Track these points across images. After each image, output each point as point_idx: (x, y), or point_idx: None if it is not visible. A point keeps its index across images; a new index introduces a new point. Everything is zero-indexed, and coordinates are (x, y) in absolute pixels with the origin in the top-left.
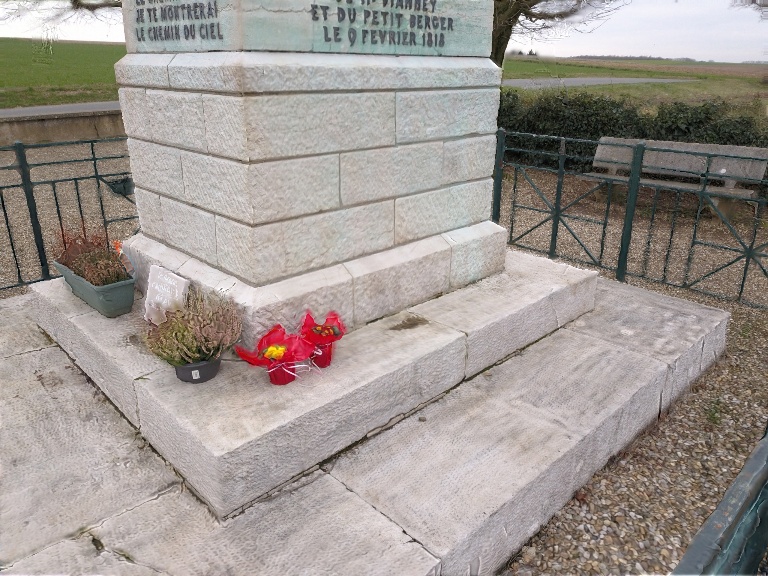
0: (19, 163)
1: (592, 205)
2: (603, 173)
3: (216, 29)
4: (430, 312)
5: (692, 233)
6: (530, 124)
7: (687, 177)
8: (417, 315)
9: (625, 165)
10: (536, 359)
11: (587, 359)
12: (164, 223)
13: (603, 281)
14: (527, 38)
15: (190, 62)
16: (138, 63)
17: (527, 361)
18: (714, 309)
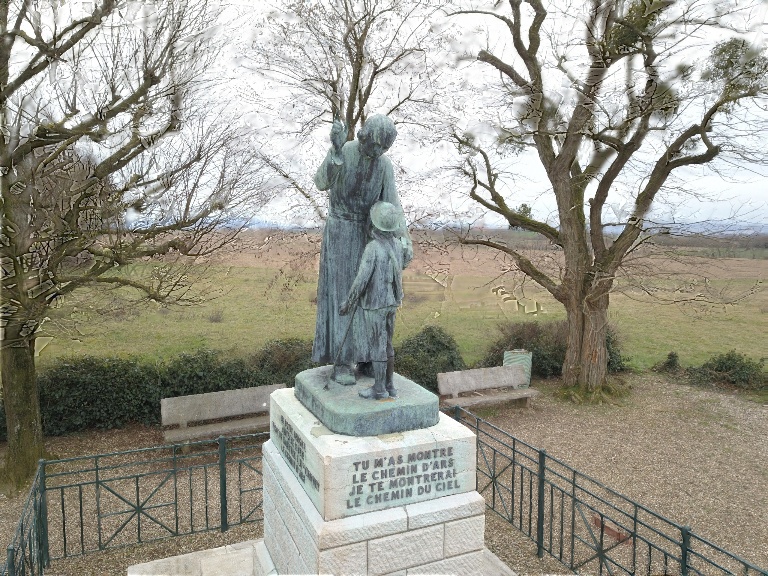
0: None
1: (184, 459)
2: (177, 429)
3: (453, 483)
4: None
5: None
6: None
7: (243, 414)
8: None
9: (193, 417)
10: None
11: None
12: None
13: None
14: None
15: (433, 508)
16: (361, 525)
17: None
18: None
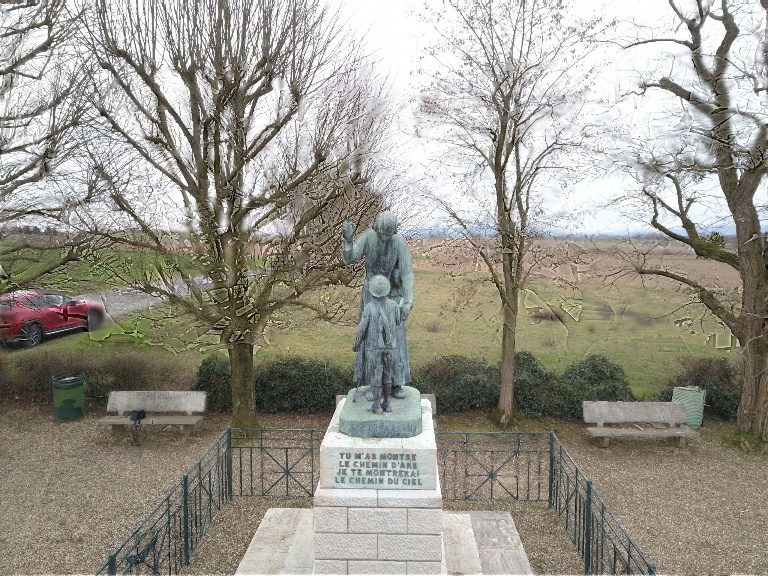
0: (111, 571)
1: None
2: None
3: (417, 481)
4: (455, 568)
5: (465, 471)
6: (261, 382)
7: None
8: (453, 572)
9: None
10: (487, 571)
11: (501, 561)
12: (351, 575)
13: (450, 513)
14: (266, 331)
15: (398, 495)
16: (343, 495)
17: (486, 573)
18: (503, 512)
